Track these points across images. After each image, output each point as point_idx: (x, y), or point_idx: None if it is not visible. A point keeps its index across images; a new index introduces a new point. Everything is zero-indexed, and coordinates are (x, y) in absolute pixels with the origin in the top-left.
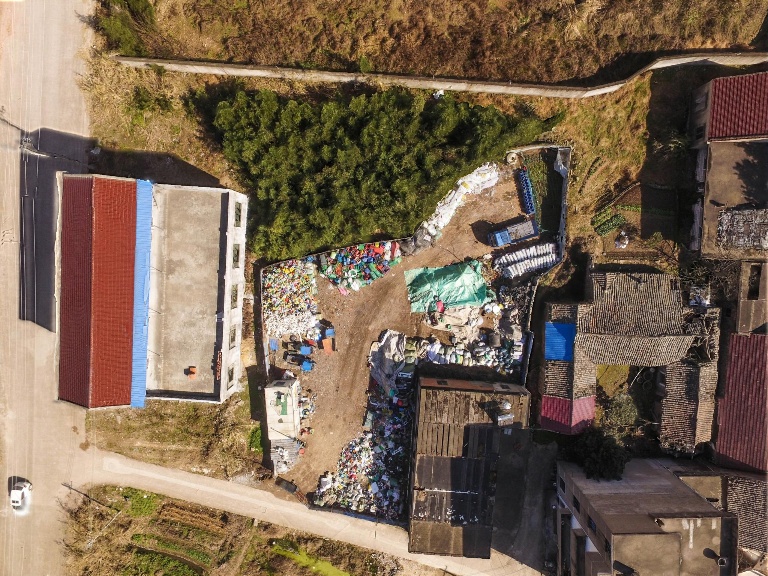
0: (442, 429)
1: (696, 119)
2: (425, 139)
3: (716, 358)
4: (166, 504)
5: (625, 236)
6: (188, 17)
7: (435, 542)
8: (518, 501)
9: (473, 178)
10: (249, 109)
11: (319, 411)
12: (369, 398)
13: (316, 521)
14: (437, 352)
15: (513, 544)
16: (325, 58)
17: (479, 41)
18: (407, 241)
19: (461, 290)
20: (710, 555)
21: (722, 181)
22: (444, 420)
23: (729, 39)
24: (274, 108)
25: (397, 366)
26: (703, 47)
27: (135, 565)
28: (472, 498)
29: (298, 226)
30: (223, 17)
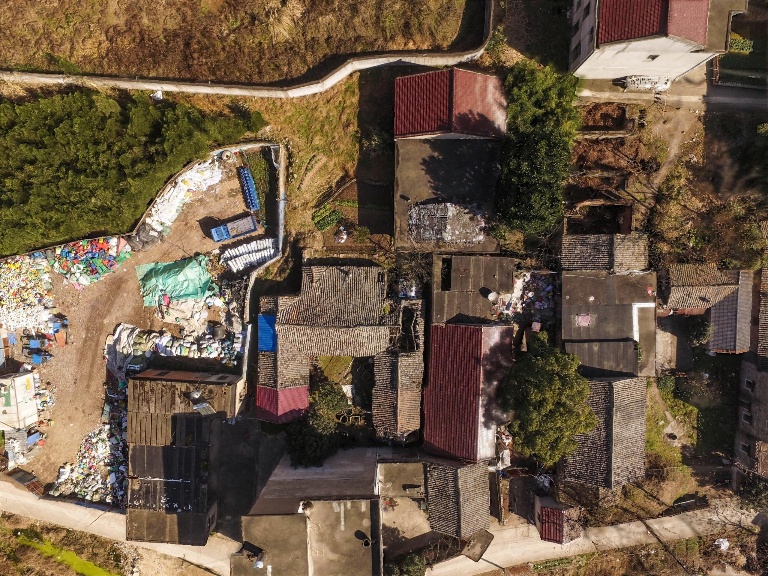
0: (150, 418)
1: None
2: None
3: (421, 348)
4: None
5: (343, 231)
6: None
7: (151, 530)
8: (250, 490)
9: (193, 175)
10: None
11: (59, 403)
12: (106, 390)
13: (56, 511)
14: (164, 344)
15: None
16: (45, 61)
17: (188, 44)
18: (131, 237)
19: (185, 284)
20: (361, 537)
21: (410, 176)
22: (151, 410)
23: (429, 41)
24: None
25: (125, 358)
26: (406, 48)
27: None
28: (185, 486)
29: (2, 222)
30: None
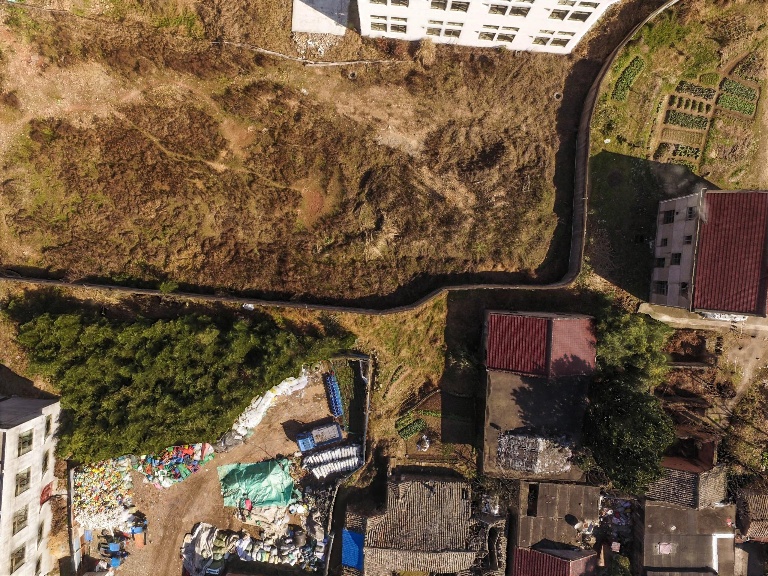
0: None
1: (484, 340)
2: None
3: (503, 566)
4: None
5: (426, 440)
6: (9, 227)
7: None
8: None
9: (280, 384)
10: (50, 331)
11: None
12: None
13: None
14: (245, 549)
15: None
16: (140, 269)
17: (284, 261)
18: (216, 442)
19: (268, 489)
20: None
21: (501, 406)
22: None
23: (517, 265)
24: (73, 332)
25: (205, 562)
26: (494, 270)
27: None
28: None
29: (96, 442)
30: (42, 229)
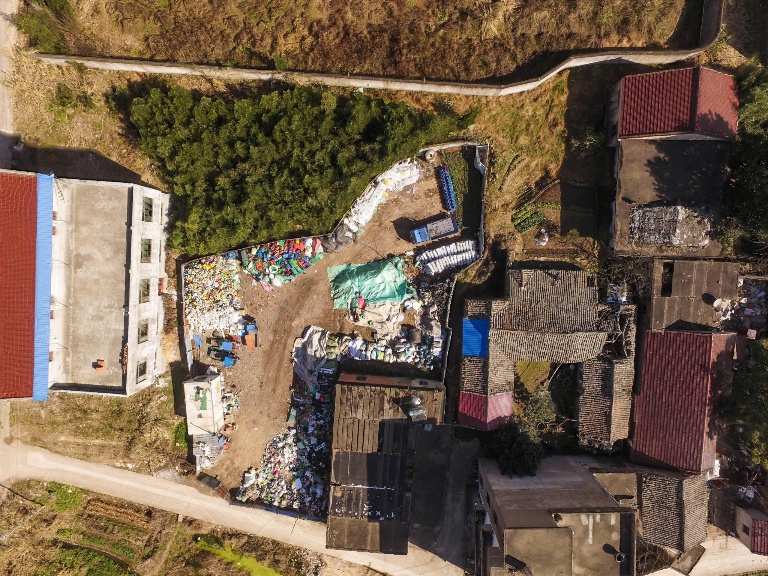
0: (357, 424)
1: (611, 117)
2: (338, 136)
3: (632, 355)
4: (91, 499)
5: (545, 233)
6: (110, 15)
7: (352, 538)
8: (441, 498)
9: (393, 175)
10: (163, 105)
11: (243, 407)
12: (293, 394)
13: (240, 517)
14: (358, 348)
15: (436, 541)
16: (245, 56)
17: (396, 39)
18: (328, 237)
19: (382, 286)
20: (610, 551)
21: (634, 178)
22: (359, 415)
23: (645, 38)
24: (188, 104)
25: (318, 362)
26: (619, 46)
27: (60, 560)
28: (388, 494)
29: (212, 221)
30: (144, 15)
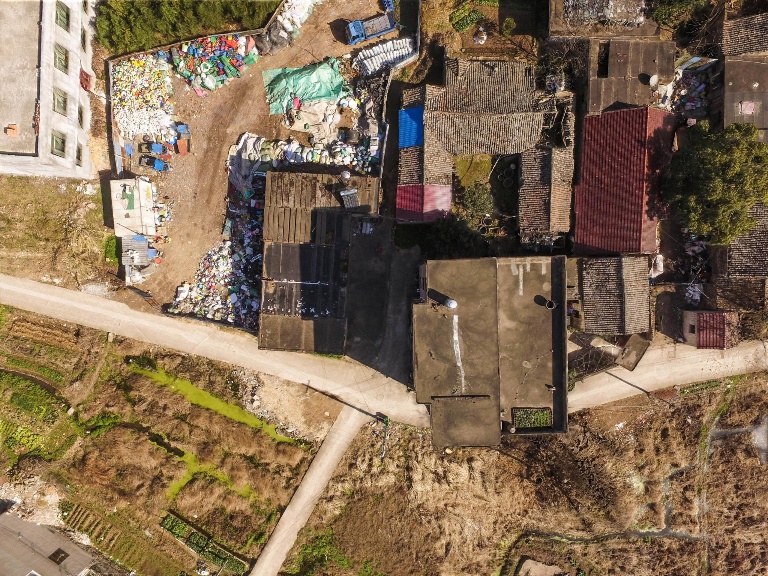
0: (289, 214)
1: None
2: None
3: (571, 145)
4: (17, 319)
5: (483, 32)
6: None
7: (285, 337)
8: (381, 309)
9: None
10: None
11: (176, 219)
12: (228, 205)
13: (173, 334)
14: (294, 151)
15: (377, 356)
16: None
17: None
18: (261, 35)
19: (317, 86)
20: (541, 302)
21: None
22: (290, 204)
23: None
24: None
25: (252, 165)
26: None
27: None
28: (323, 289)
29: None
30: None
